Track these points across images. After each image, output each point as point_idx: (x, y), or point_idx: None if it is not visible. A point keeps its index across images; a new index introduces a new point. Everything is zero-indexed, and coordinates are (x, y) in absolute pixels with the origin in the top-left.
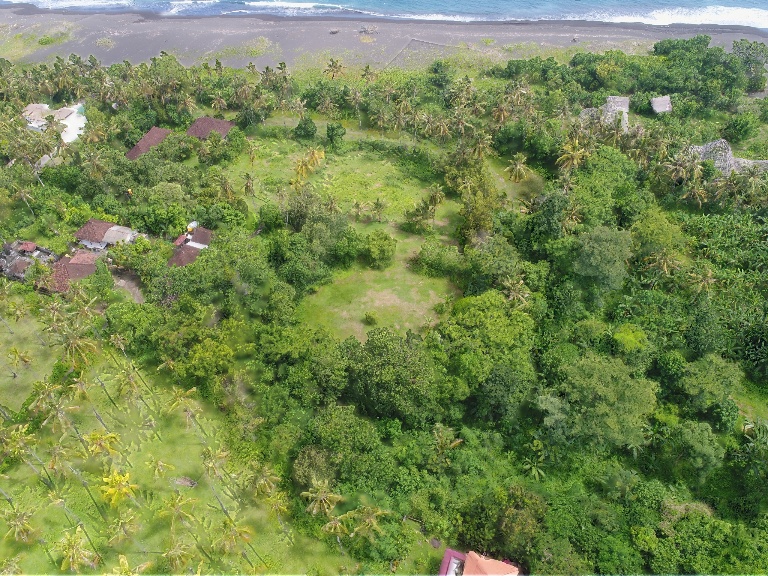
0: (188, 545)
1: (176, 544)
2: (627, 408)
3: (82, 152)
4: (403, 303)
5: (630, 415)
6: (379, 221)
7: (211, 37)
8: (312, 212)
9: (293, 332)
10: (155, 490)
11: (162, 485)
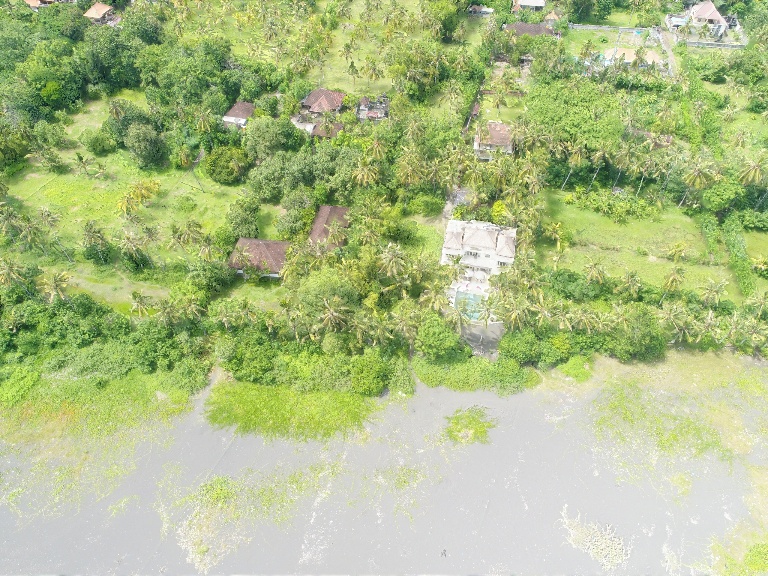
0: (203, 6)
1: (206, 3)
2: (2, 22)
3: (418, 235)
4: (94, 124)
5: (3, 20)
6: (88, 173)
7: (334, 572)
8: (132, 106)
9: (156, 52)
10: (235, 43)
11: (233, 44)
